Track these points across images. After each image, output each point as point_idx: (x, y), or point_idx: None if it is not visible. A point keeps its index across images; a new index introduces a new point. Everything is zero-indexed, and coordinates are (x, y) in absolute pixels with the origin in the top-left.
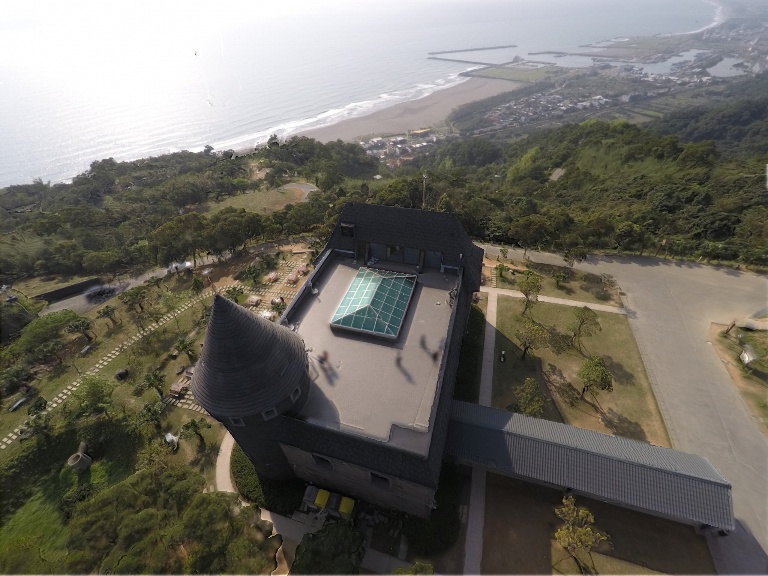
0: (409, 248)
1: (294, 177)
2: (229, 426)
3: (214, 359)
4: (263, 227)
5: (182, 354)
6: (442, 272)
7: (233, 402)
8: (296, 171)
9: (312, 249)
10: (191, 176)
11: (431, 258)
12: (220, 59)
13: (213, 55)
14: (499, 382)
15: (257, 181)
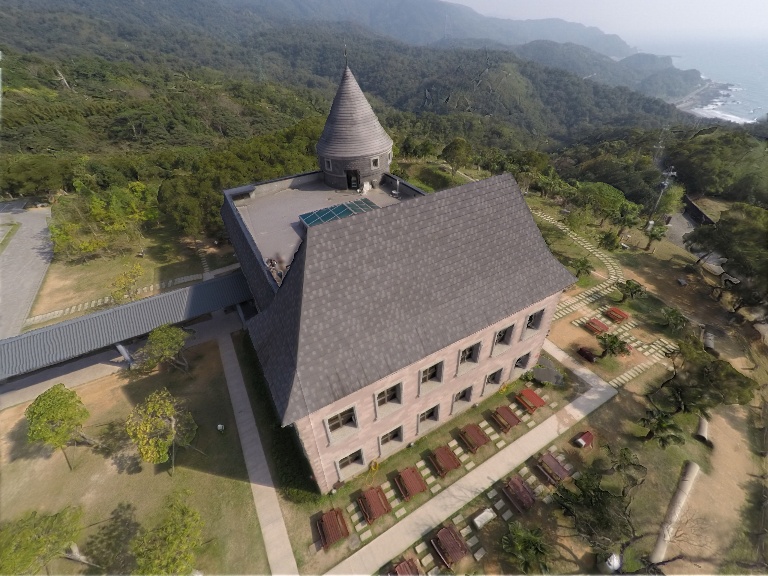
0: None
1: None
2: None
3: None
4: None
5: None
6: None
7: None
8: None
9: None
10: None
11: None
12: None
13: None
14: (219, 393)
15: None
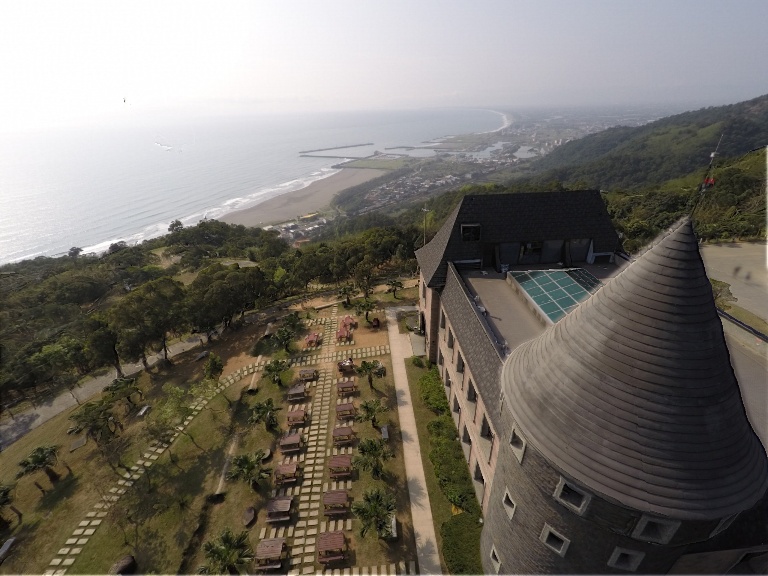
0: (551, 241)
1: (216, 257)
2: (648, 553)
3: (693, 377)
4: (267, 284)
5: (233, 487)
6: (592, 263)
7: (740, 472)
8: (217, 251)
9: (340, 300)
10: (81, 270)
11: (574, 249)
12: (161, 105)
13: (151, 101)
14: None
15: (175, 265)
